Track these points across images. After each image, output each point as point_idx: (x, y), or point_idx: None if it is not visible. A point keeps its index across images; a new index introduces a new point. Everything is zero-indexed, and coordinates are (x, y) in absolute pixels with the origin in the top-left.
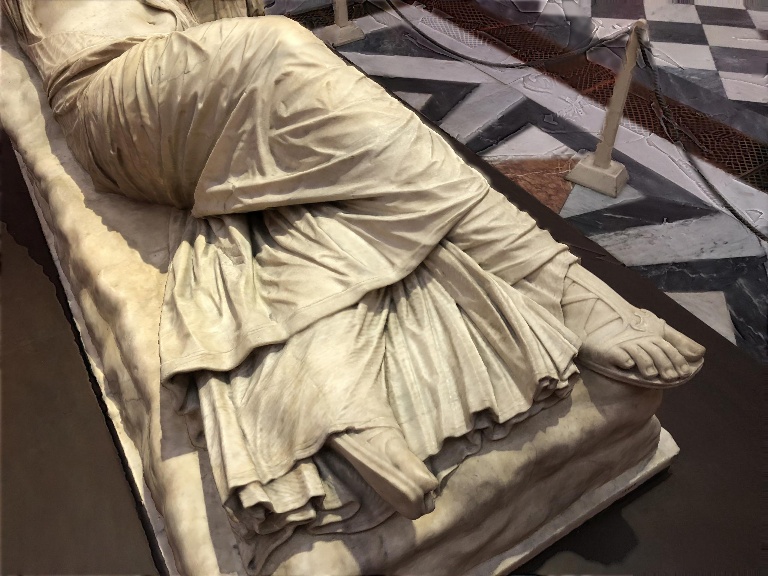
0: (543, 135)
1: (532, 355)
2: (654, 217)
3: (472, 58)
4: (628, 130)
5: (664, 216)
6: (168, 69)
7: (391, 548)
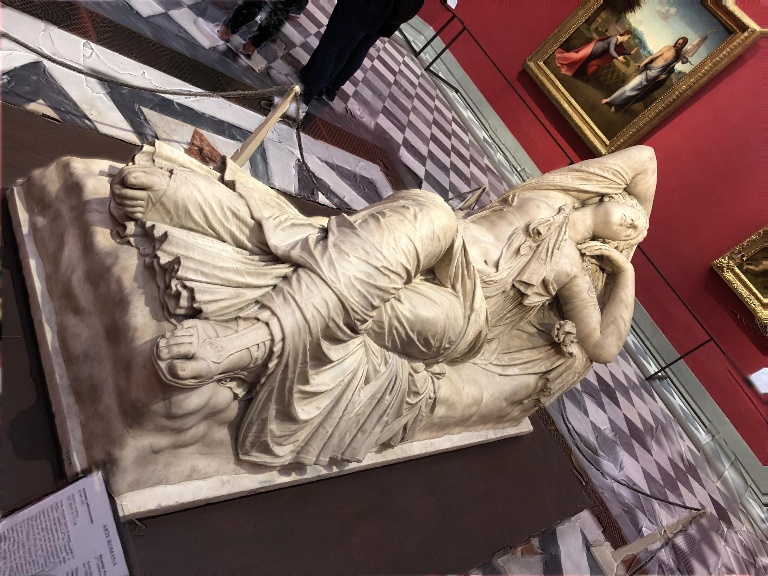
0: None
1: (198, 262)
2: None
3: None
4: None
5: None
6: None
7: (94, 215)
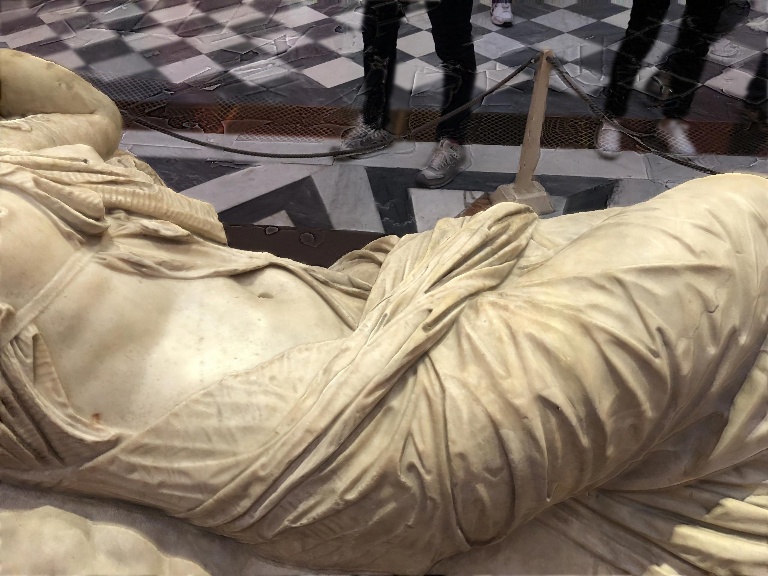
0: (436, 192)
1: None
2: None
3: (331, 152)
4: (548, 150)
5: (598, 205)
6: (673, 322)
7: None
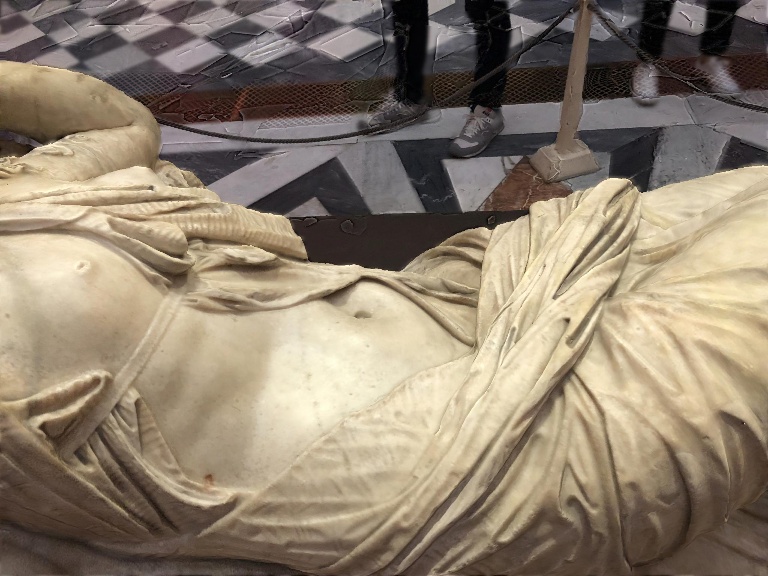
0: (472, 161)
1: None
2: (649, 162)
3: (361, 131)
4: (591, 104)
5: (645, 158)
6: None
7: None
